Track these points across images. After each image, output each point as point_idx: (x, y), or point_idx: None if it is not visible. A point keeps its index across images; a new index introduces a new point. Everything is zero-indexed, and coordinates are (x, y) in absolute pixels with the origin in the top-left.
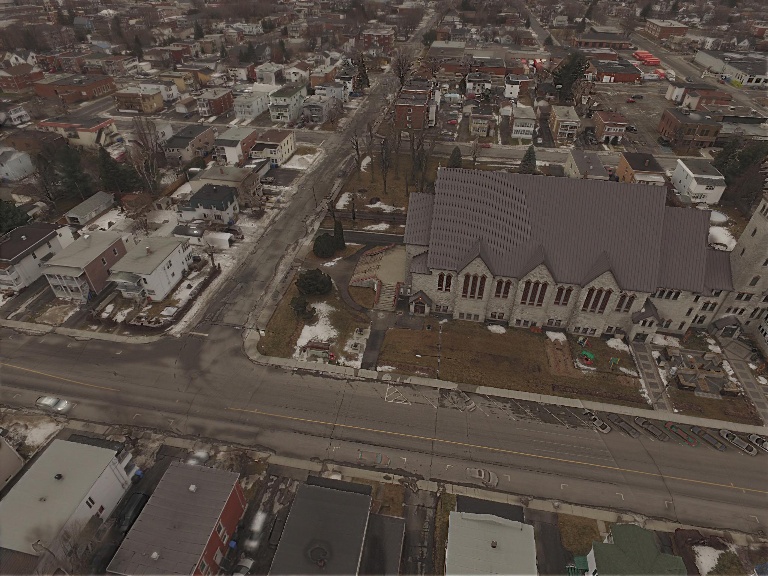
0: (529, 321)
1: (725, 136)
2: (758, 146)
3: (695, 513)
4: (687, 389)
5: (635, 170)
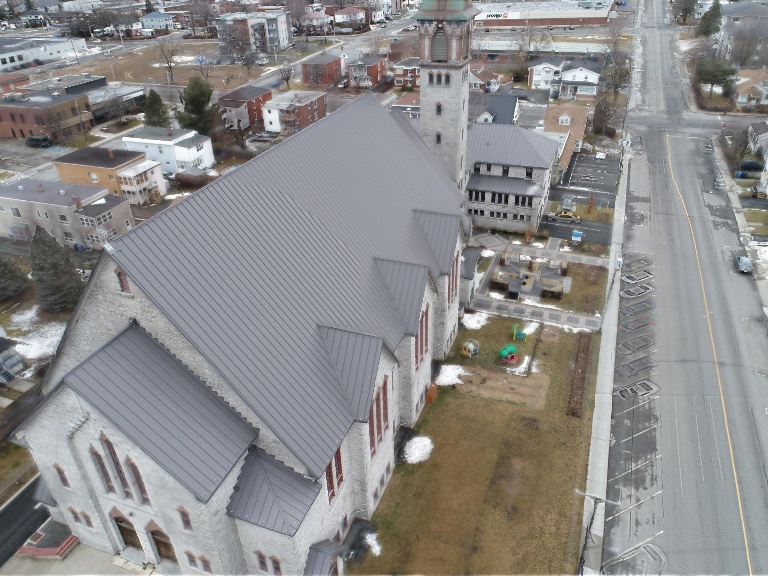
0: (423, 391)
1: (98, 107)
2: (196, 82)
3: (762, 357)
4: (562, 294)
5: (115, 167)
